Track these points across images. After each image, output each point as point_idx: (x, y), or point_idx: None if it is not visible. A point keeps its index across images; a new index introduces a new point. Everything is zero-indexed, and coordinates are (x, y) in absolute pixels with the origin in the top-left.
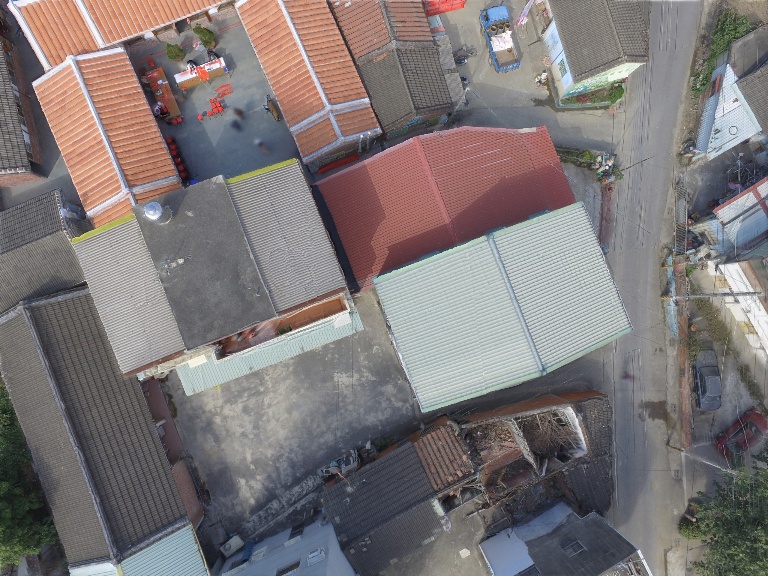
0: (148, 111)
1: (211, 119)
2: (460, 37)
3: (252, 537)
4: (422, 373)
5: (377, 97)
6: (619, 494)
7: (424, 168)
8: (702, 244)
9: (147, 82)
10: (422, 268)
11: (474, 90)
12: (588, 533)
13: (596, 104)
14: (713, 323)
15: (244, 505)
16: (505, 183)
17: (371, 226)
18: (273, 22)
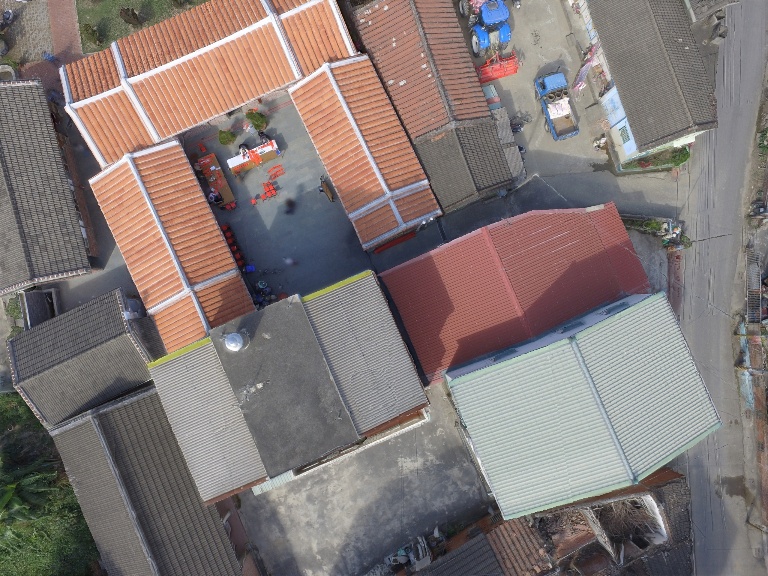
0: (205, 204)
1: (264, 202)
2: (514, 103)
3: None
4: (503, 479)
5: (436, 177)
6: (698, 575)
7: (494, 259)
8: None
9: (200, 169)
10: (500, 371)
11: (530, 158)
12: None
13: (658, 167)
14: None
15: None
16: (576, 267)
17: (439, 318)
18: (328, 107)
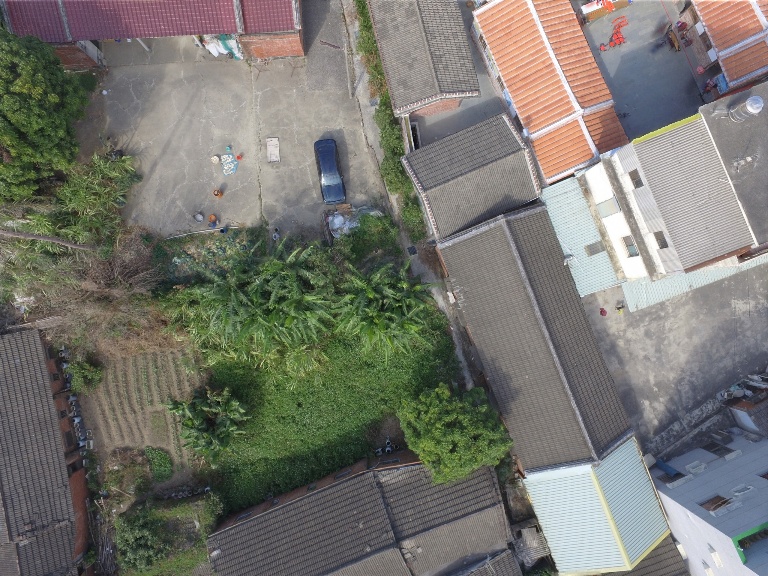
0: (584, 37)
1: (609, 50)
2: None
3: (660, 456)
4: None
5: None
6: None
7: None
8: None
9: None
10: None
11: None
12: None
13: None
14: None
15: (648, 426)
16: None
17: None
18: None
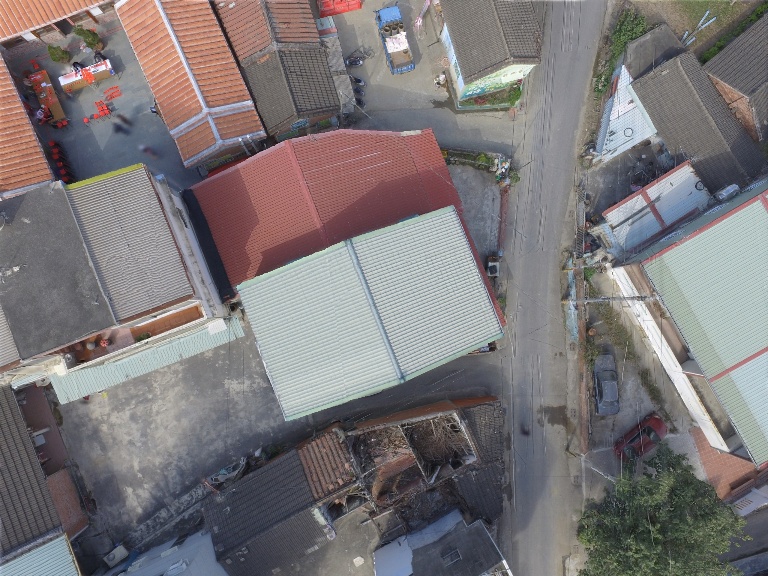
0: (23, 114)
1: (99, 122)
2: (357, 38)
3: (138, 547)
4: (285, 381)
5: (261, 99)
6: (517, 500)
7: (295, 172)
8: (599, 247)
9: (30, 85)
10: (283, 274)
11: (371, 92)
12: (468, 542)
13: (496, 106)
14: (613, 327)
15: (131, 514)
16: (384, 187)
17: (245, 231)
18: (151, 23)
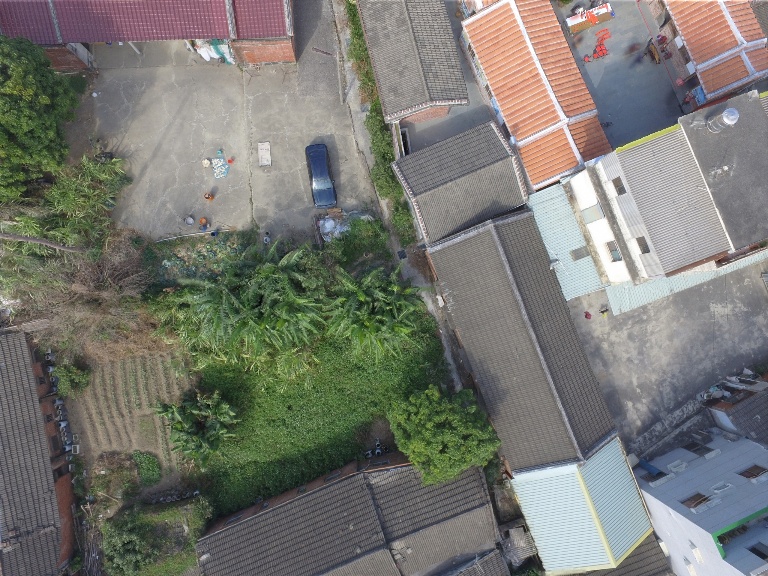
0: (569, 49)
1: (592, 62)
2: None
3: (643, 456)
4: None
5: None
6: None
7: None
8: None
9: None
10: None
11: None
12: None
13: None
14: None
15: (632, 426)
16: None
17: None
18: None
